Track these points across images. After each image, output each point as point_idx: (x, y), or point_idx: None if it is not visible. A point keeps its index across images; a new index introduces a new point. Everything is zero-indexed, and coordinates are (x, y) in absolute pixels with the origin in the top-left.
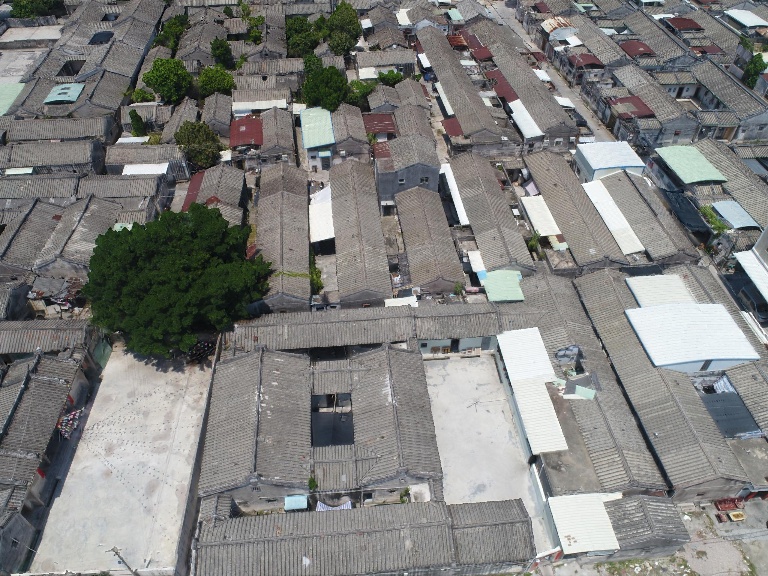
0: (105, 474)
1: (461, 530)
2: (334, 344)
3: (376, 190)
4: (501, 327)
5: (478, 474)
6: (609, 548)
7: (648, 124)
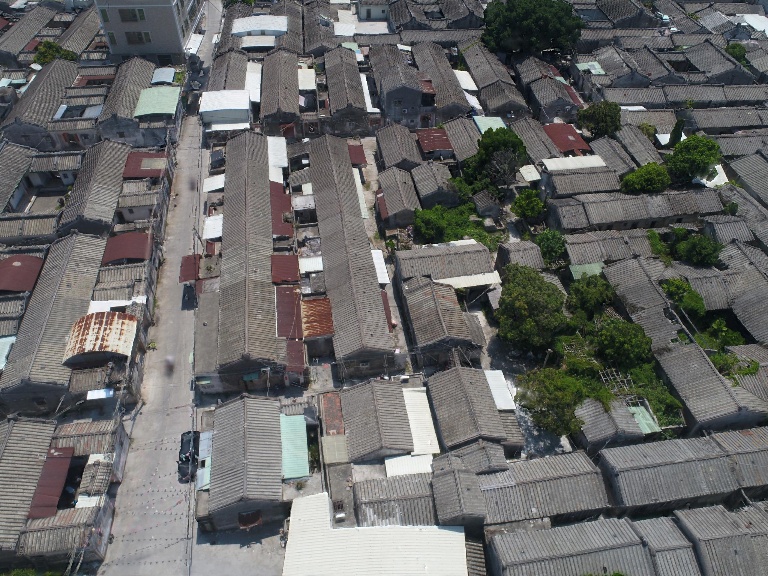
0: None
1: None
2: None
3: None
4: None
5: (372, 27)
6: None
7: None
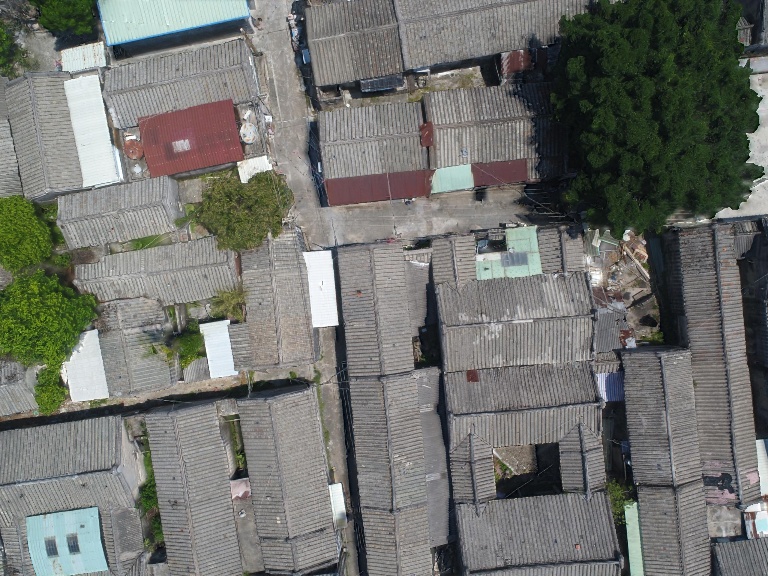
0: None
1: None
2: None
3: None
4: None
5: None
6: None
7: None
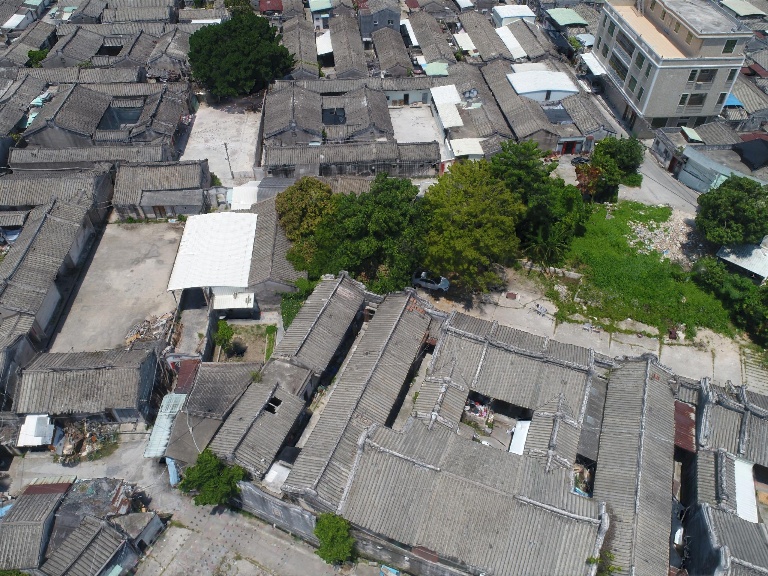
0: (206, 149)
1: (402, 147)
2: (334, 91)
3: (359, 31)
4: (433, 84)
5: None
6: (478, 154)
7: (546, 0)
